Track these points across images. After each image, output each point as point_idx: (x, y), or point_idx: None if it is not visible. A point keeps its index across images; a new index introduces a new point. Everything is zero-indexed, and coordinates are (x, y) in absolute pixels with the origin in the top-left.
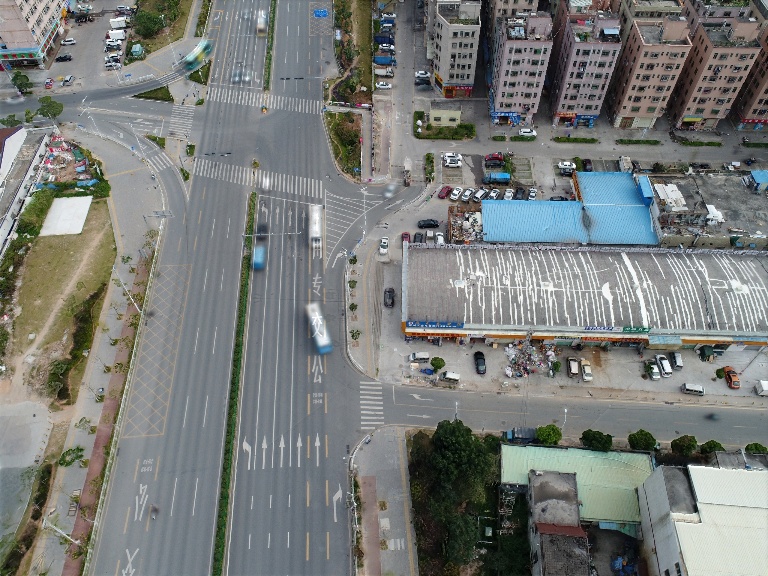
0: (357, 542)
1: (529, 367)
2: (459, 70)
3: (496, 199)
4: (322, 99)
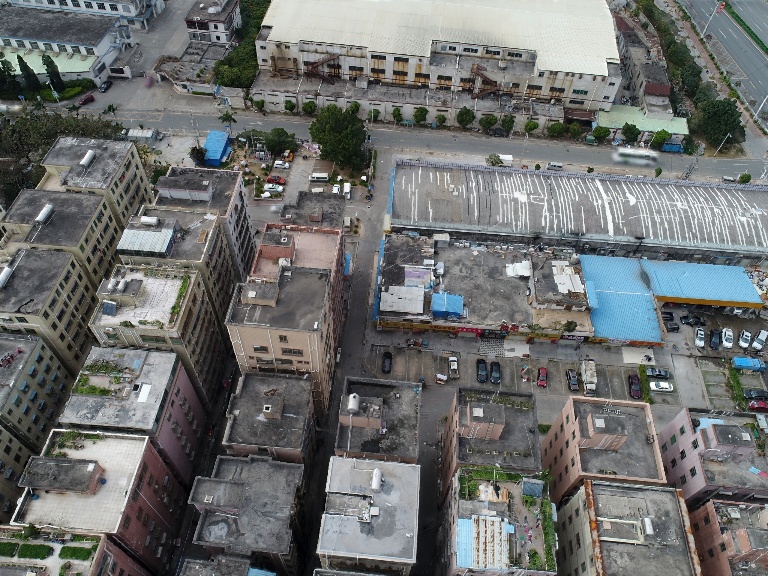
0: None
1: None
2: None
3: None
4: None
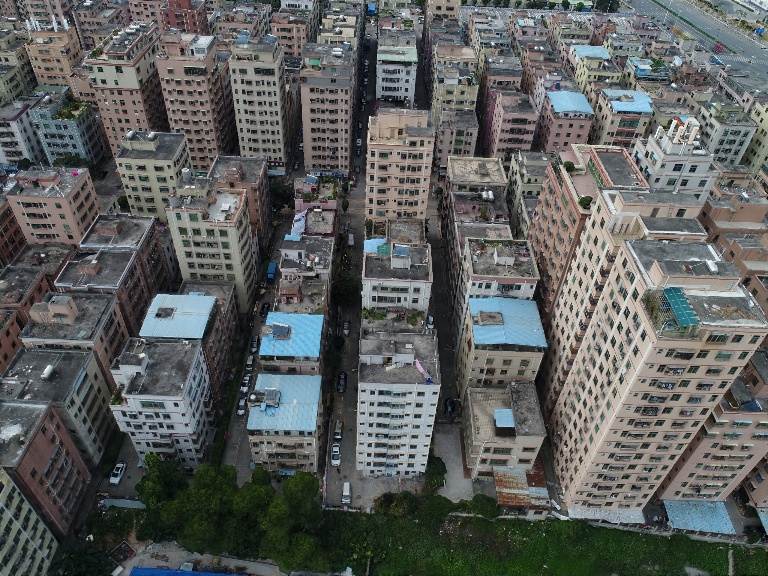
0: None
1: None
2: None
3: None
4: None
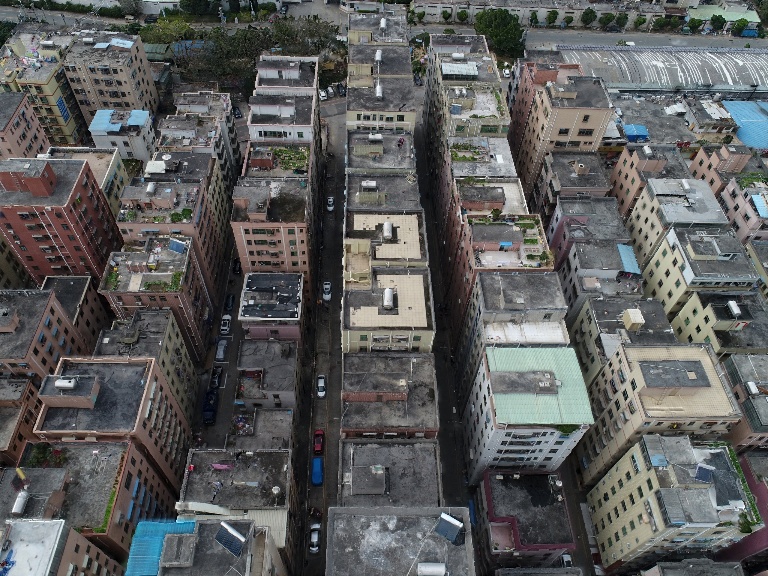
0: None
1: None
2: None
3: None
4: None
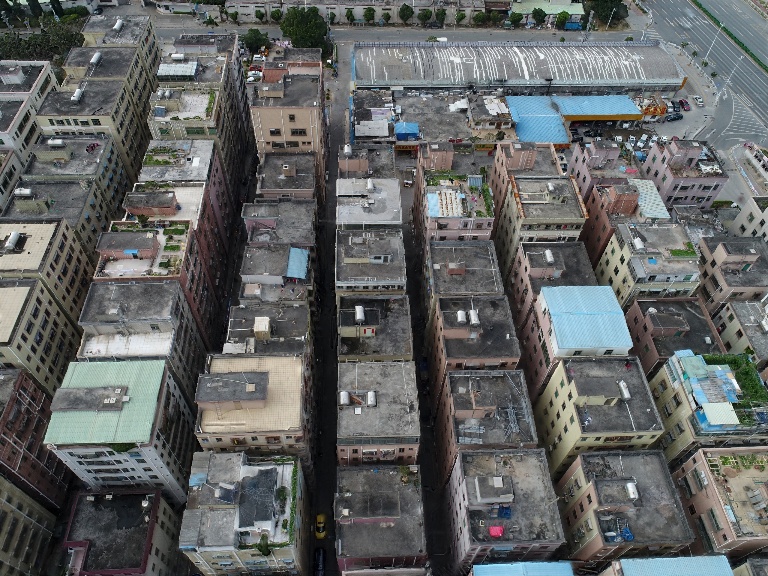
0: (634, 0)
1: None
2: None
3: None
4: None
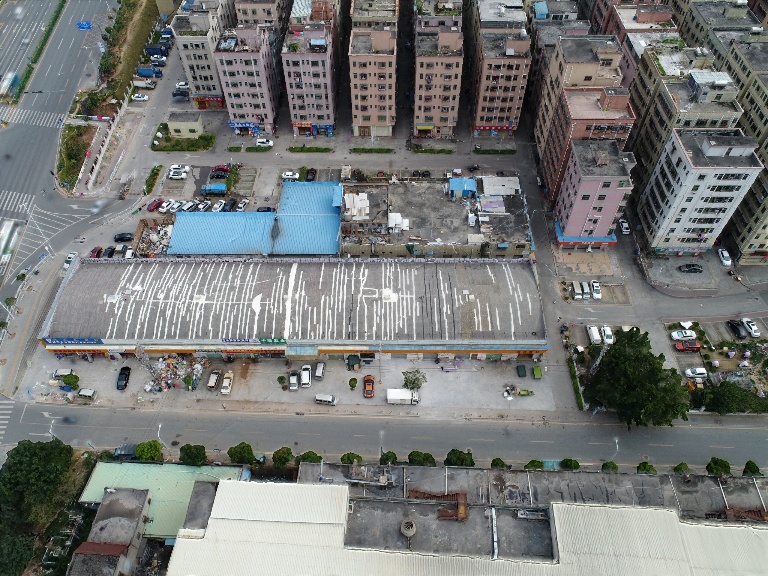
0: None
1: (170, 381)
2: (203, 81)
3: (205, 211)
4: (68, 112)
